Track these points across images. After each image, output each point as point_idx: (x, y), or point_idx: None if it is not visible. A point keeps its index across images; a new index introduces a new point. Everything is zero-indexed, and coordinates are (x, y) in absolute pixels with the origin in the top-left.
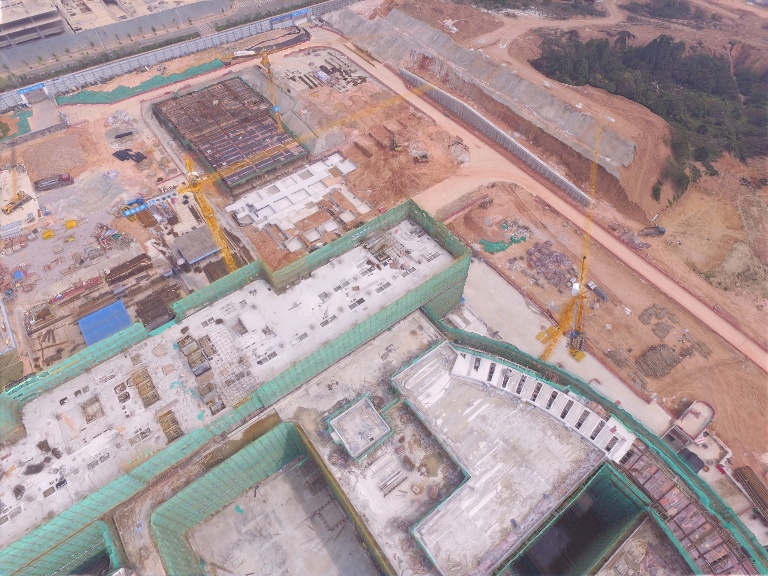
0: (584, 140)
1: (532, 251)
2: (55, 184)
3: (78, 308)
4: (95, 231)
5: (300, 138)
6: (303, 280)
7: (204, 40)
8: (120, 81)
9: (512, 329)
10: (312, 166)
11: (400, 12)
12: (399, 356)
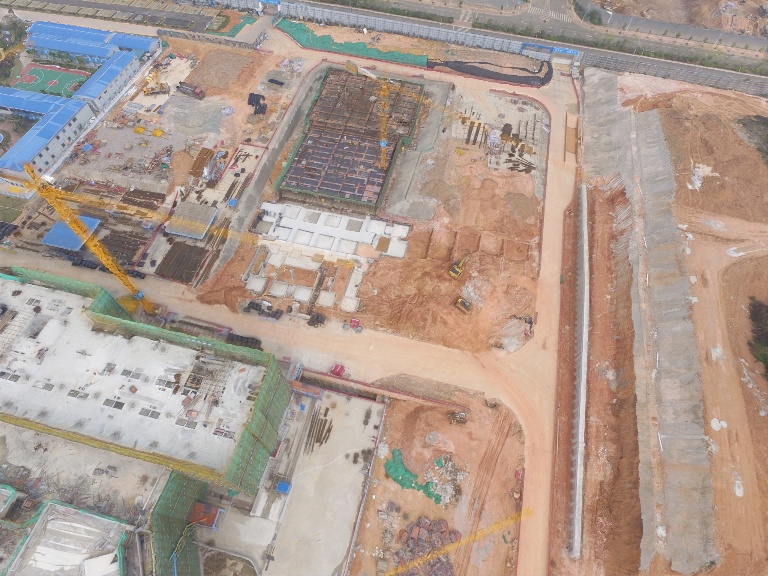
0: (667, 472)
1: (423, 523)
2: (189, 92)
3: (88, 201)
4: (161, 150)
5: (397, 185)
6: (121, 336)
7: (439, 30)
8: (334, 31)
9: (288, 574)
10: (373, 221)
11: (658, 118)
12: (105, 486)
